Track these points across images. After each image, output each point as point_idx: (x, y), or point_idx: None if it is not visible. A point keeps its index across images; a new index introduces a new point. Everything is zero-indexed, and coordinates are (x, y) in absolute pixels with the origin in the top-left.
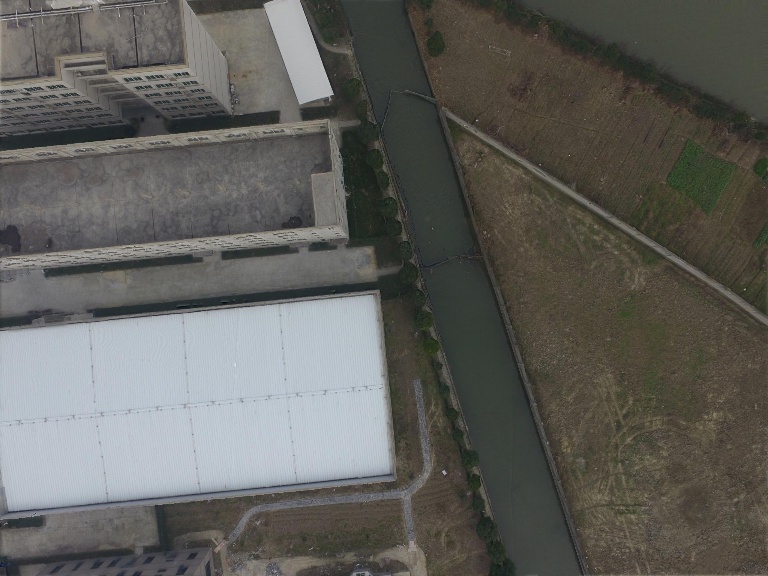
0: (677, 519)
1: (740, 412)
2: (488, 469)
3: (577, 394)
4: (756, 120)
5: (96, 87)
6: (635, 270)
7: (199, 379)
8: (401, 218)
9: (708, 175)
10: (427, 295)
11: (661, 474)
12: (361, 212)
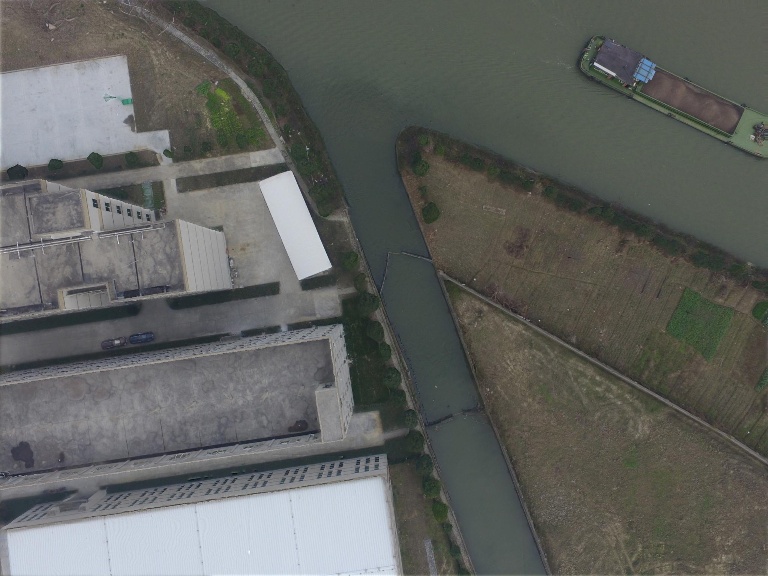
0: None
1: (749, 553)
2: None
3: (586, 544)
4: (753, 265)
5: (98, 293)
6: (638, 419)
7: (214, 567)
8: (404, 381)
9: (707, 322)
10: (434, 456)
11: None
12: (365, 379)
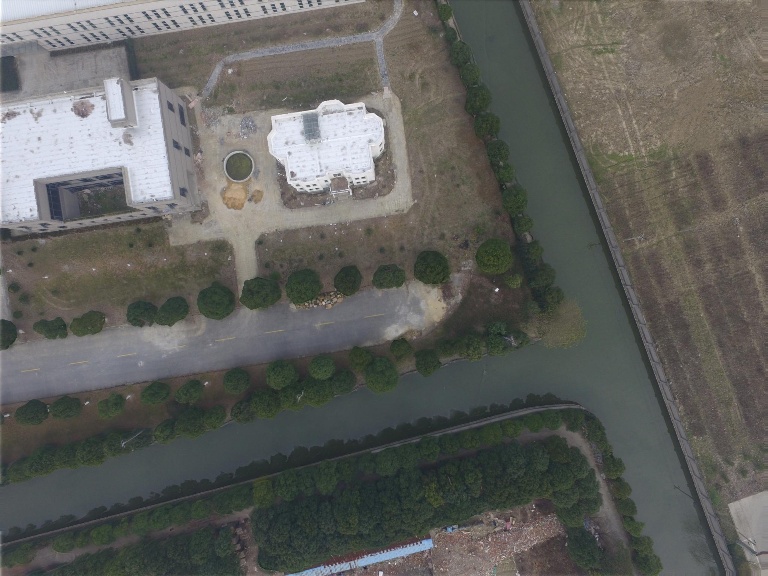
0: (657, 56)
1: None
2: (460, 7)
3: None
4: None
5: None
6: None
7: None
8: None
9: None
10: None
11: (638, 11)
12: None
